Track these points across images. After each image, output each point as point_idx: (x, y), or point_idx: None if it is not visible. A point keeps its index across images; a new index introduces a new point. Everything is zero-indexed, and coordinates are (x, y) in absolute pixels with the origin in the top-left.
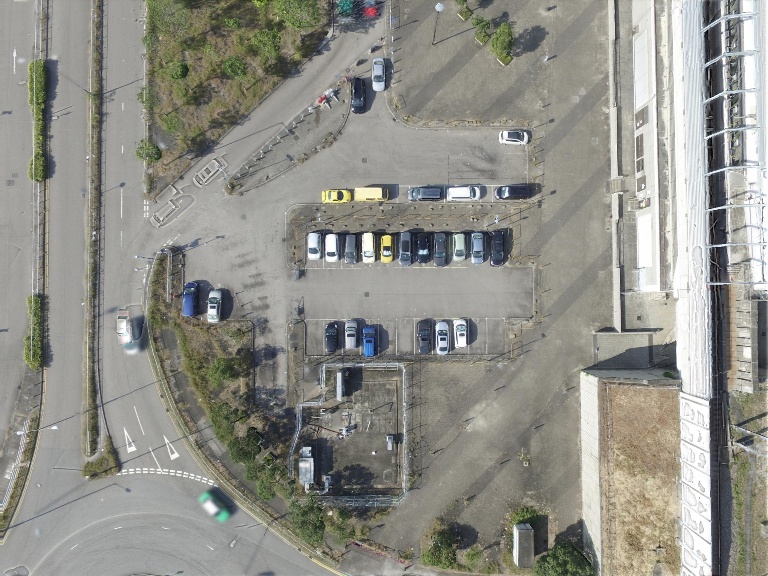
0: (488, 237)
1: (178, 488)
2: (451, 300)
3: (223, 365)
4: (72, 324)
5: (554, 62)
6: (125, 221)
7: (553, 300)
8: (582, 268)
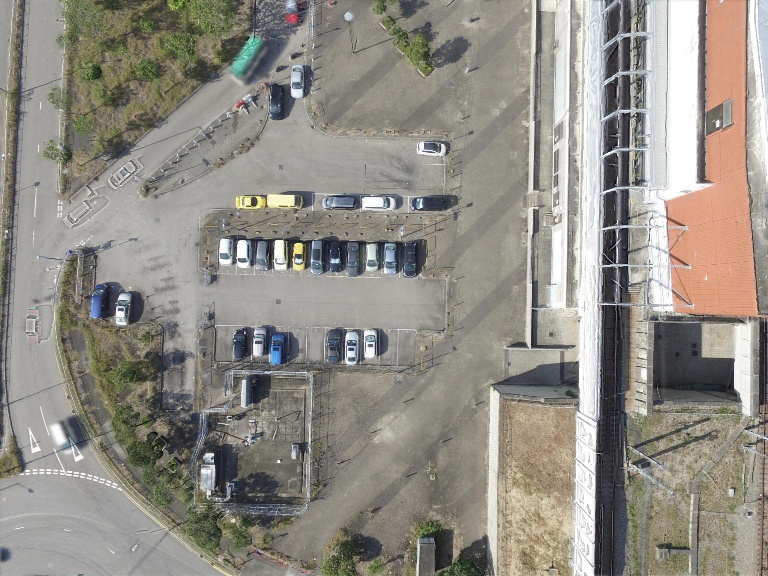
0: (402, 248)
1: (81, 490)
2: (363, 310)
3: (125, 368)
4: None
5: (475, 74)
6: (38, 220)
7: (466, 313)
8: (496, 282)
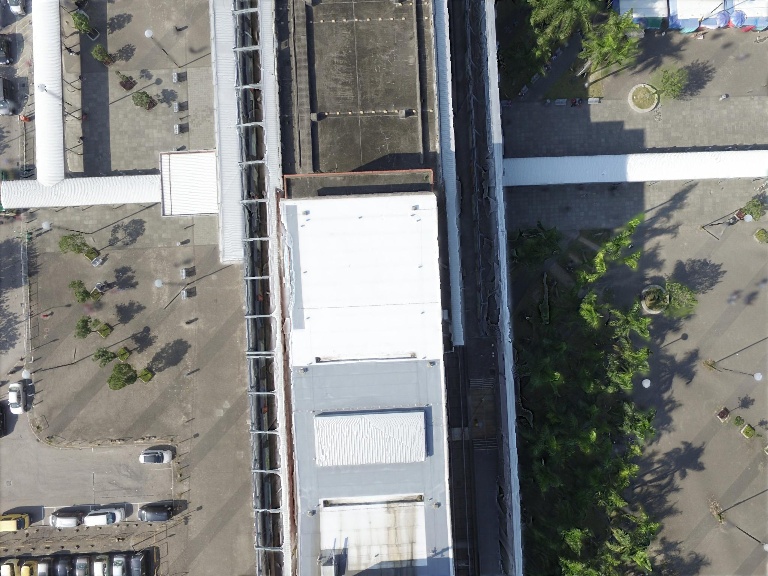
0: None
1: None
2: None
3: None
4: None
5: (197, 375)
6: None
7: None
8: None
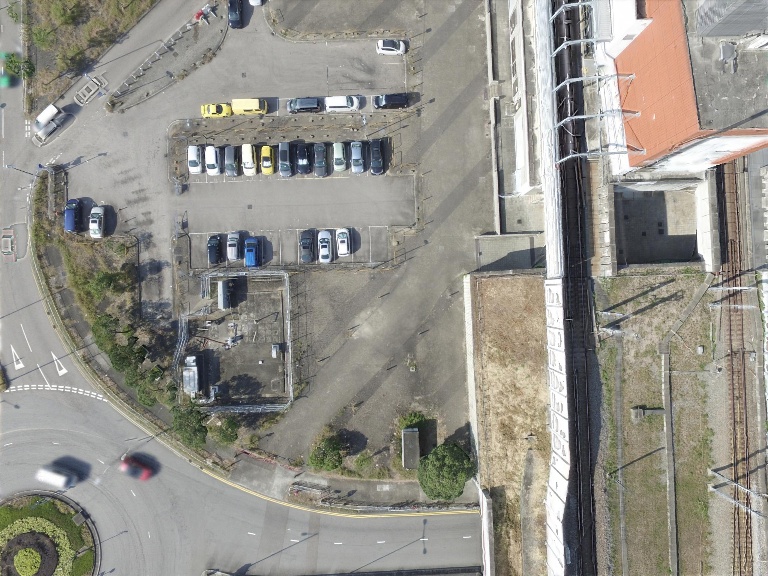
0: (369, 147)
1: (67, 403)
2: (334, 210)
3: (101, 275)
4: None
5: None
6: (7, 141)
7: (435, 207)
8: (463, 174)
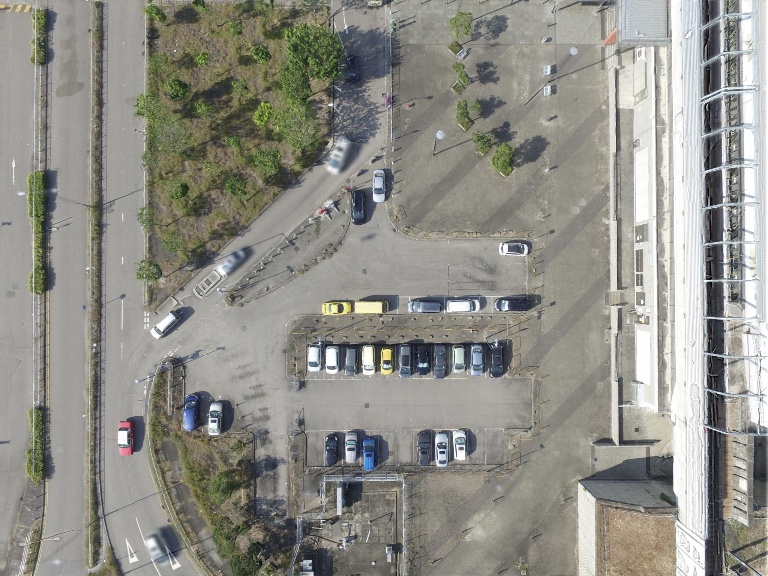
0: (488, 348)
1: None
2: (450, 411)
3: (224, 483)
4: (73, 436)
5: (555, 172)
6: (126, 333)
7: (552, 411)
8: (581, 379)
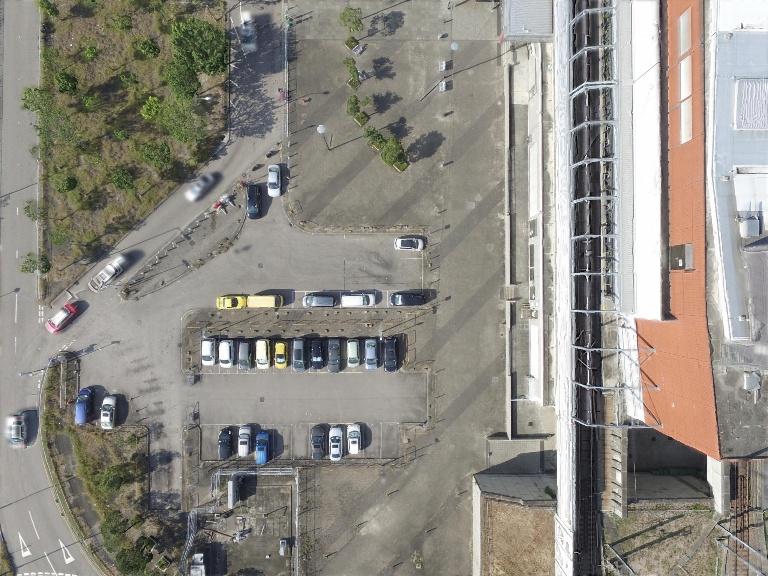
0: (383, 343)
1: None
2: (346, 405)
3: (112, 477)
4: None
5: (450, 168)
6: (20, 327)
7: (447, 405)
8: (476, 374)
